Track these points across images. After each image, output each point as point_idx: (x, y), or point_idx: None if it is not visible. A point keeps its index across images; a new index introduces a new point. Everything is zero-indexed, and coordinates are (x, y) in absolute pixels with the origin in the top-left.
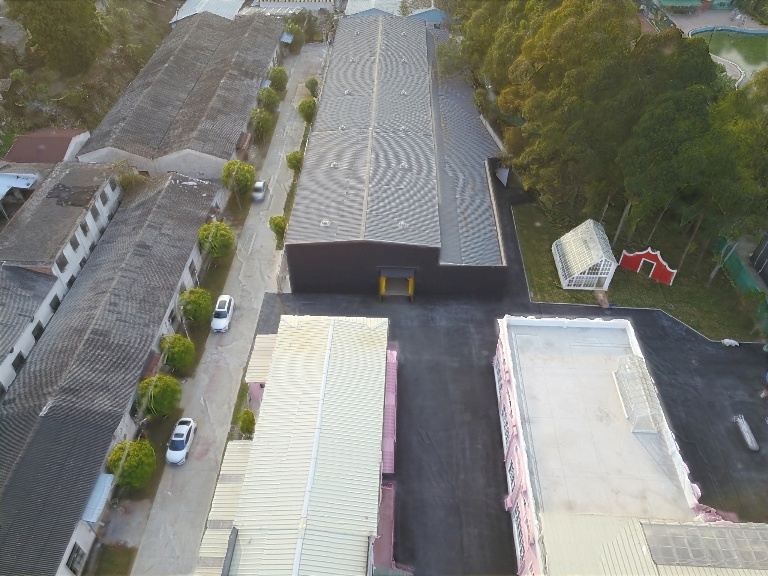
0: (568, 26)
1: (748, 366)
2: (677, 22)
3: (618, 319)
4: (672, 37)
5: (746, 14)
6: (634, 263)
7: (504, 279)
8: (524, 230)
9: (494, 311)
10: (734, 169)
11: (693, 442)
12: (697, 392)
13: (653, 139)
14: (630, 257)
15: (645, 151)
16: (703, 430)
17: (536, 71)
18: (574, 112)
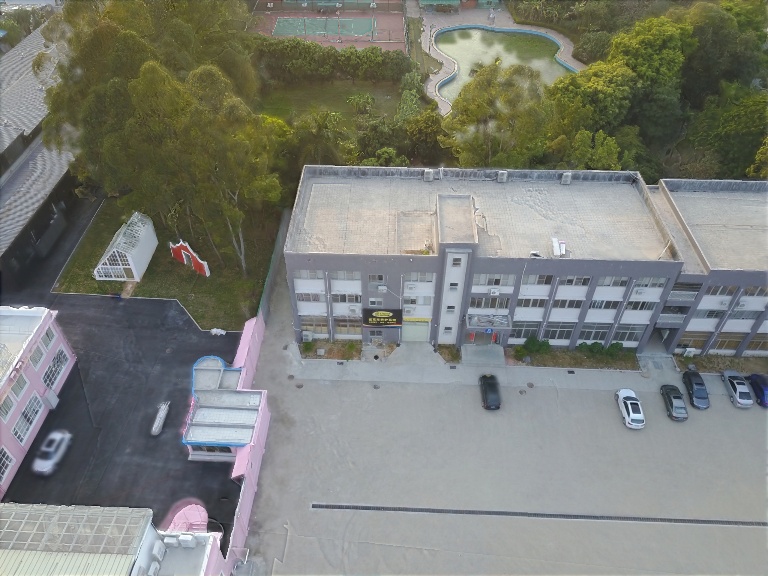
0: (50, 21)
1: (217, 354)
2: (432, 20)
3: (37, 307)
4: (100, 31)
5: (507, 13)
6: (180, 255)
7: (40, 270)
8: (102, 223)
9: (4, 301)
10: (165, 161)
11: (101, 427)
12: (146, 379)
13: (90, 131)
14: (175, 249)
15: (88, 143)
16: (121, 416)
17: (55, 65)
18: (57, 105)
